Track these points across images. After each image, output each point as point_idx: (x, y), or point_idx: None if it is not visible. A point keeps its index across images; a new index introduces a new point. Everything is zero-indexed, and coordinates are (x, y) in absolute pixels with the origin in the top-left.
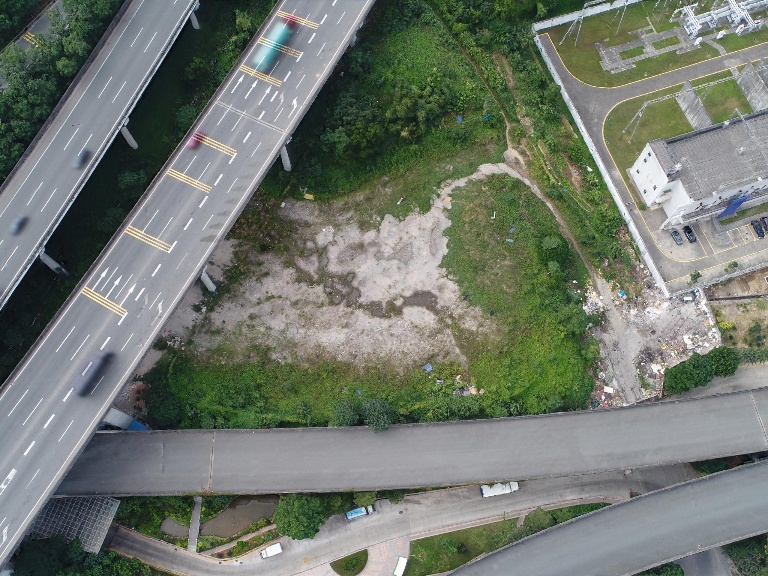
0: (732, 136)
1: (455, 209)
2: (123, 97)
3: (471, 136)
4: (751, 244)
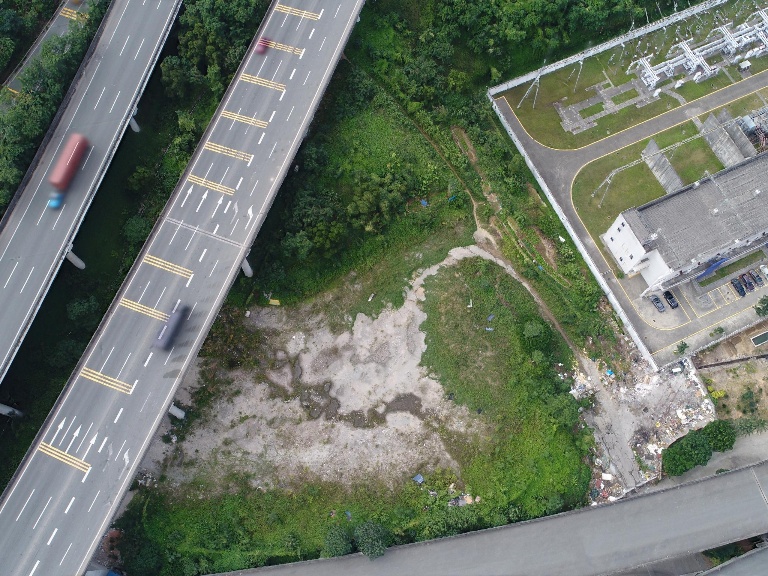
0: (704, 196)
1: (429, 300)
2: (64, 222)
3: (438, 219)
4: (733, 304)
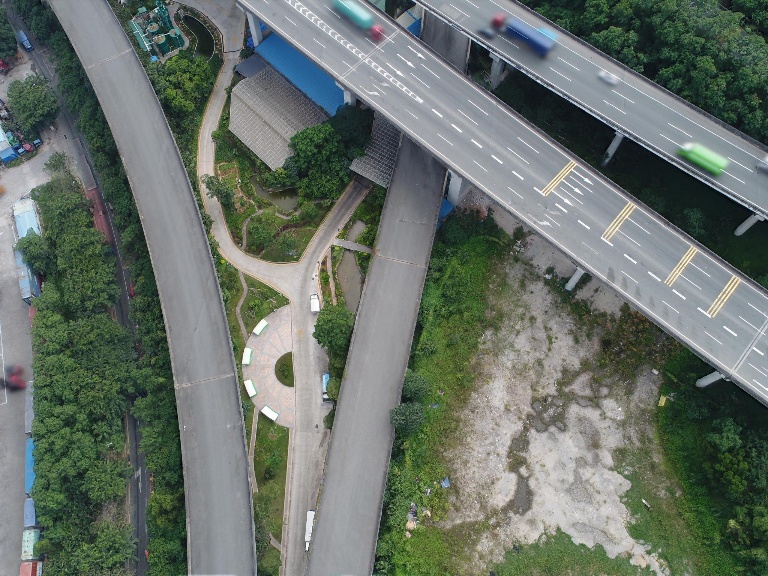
0: None
1: (629, 568)
2: None
3: None
4: None
